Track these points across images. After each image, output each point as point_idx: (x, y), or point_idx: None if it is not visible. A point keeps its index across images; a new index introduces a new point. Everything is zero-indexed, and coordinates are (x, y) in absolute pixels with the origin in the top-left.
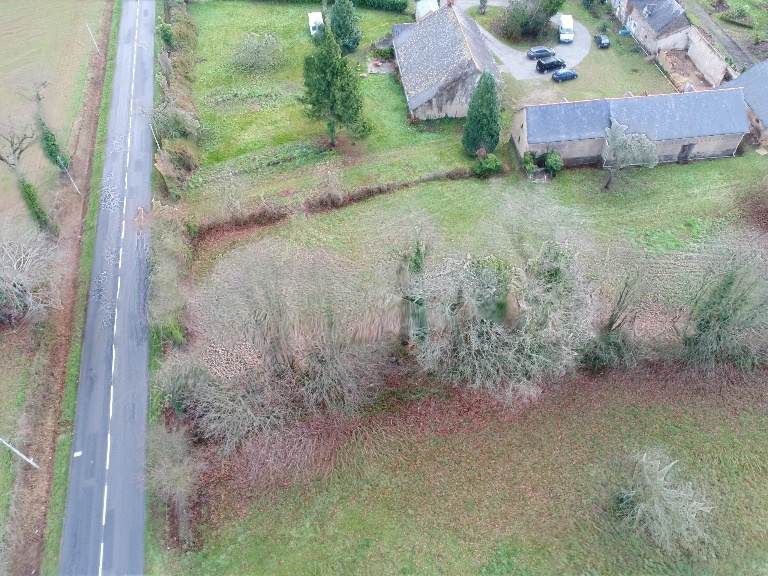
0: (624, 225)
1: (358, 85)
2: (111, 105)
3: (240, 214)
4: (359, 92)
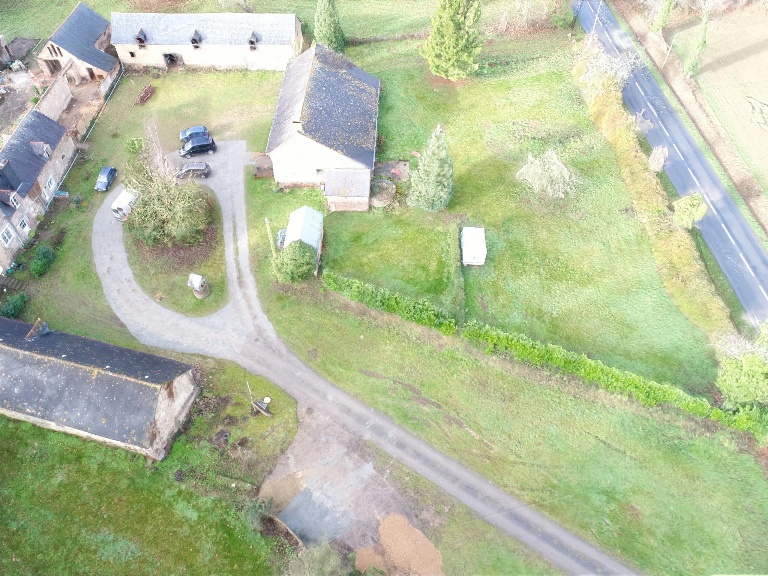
0: (265, 3)
1: (424, 141)
2: (702, 153)
3: (520, 9)
4: (424, 131)
